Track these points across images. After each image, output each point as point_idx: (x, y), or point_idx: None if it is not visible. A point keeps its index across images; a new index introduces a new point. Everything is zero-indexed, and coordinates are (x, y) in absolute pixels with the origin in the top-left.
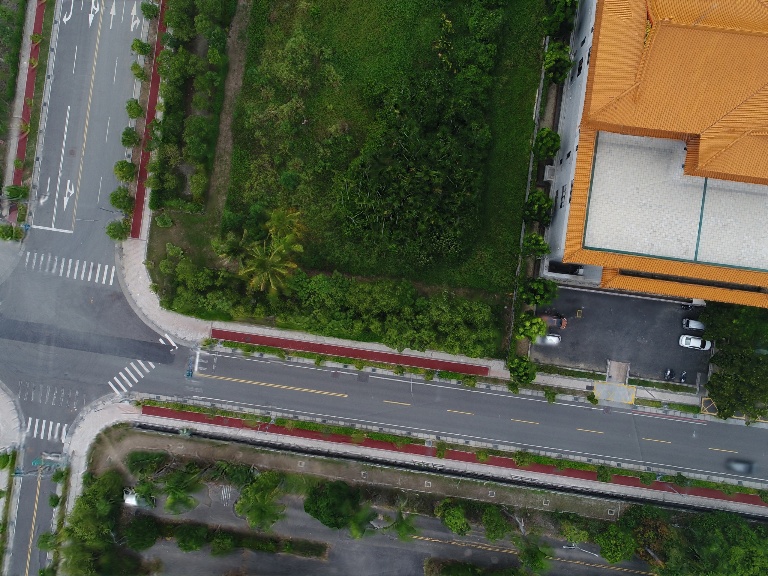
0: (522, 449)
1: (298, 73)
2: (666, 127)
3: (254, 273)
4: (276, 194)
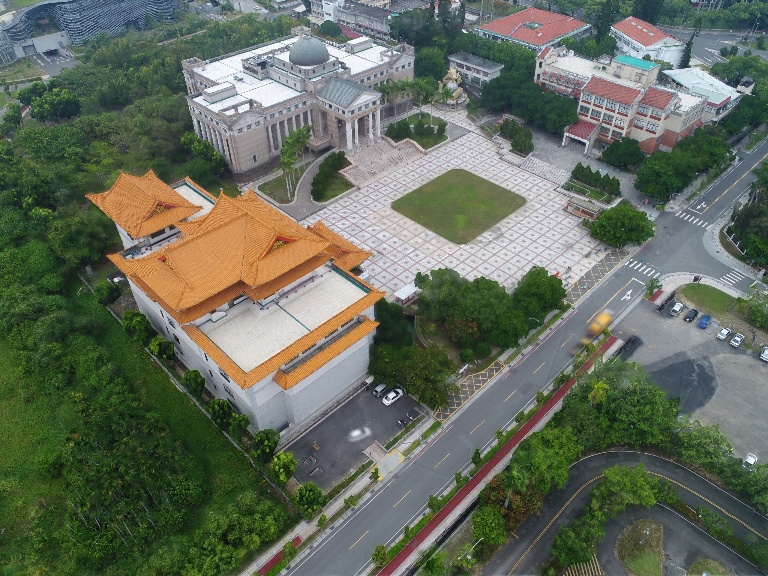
0: None
1: None
2: (221, 288)
3: None
4: None
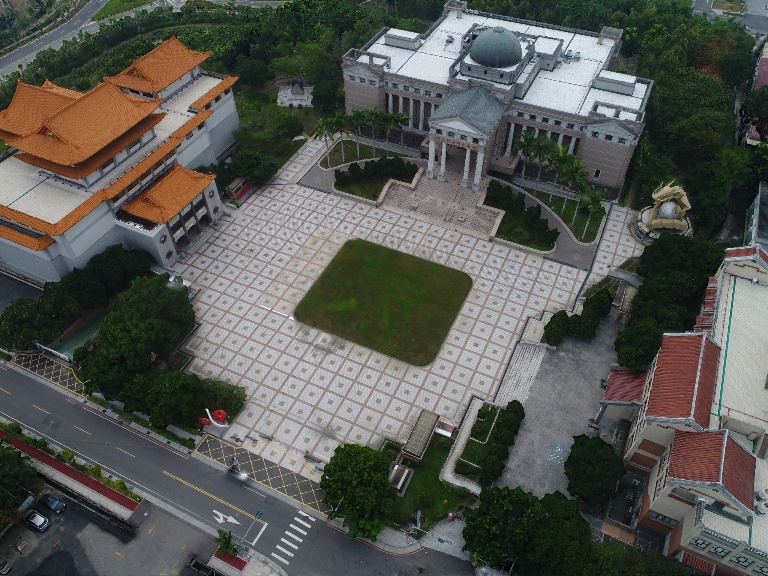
0: None
1: None
2: (12, 131)
3: None
4: None
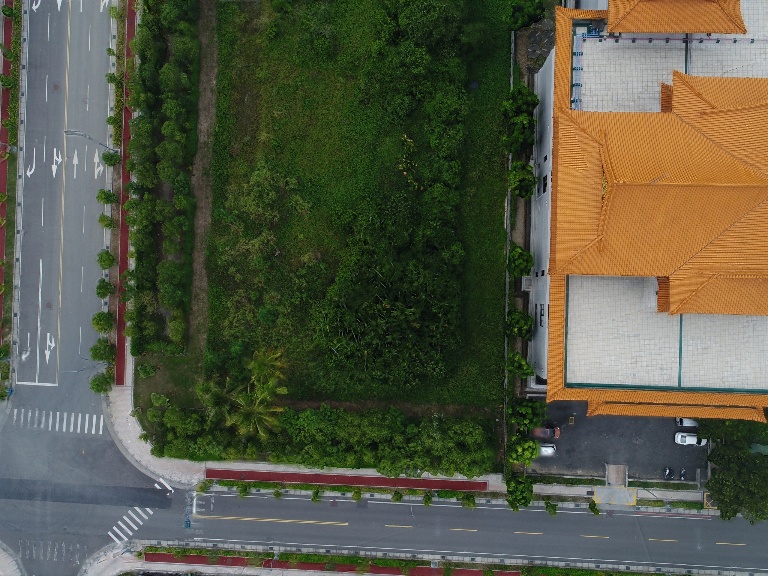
0: (529, 561)
1: (265, 206)
2: (634, 273)
3: (240, 427)
4: (256, 329)
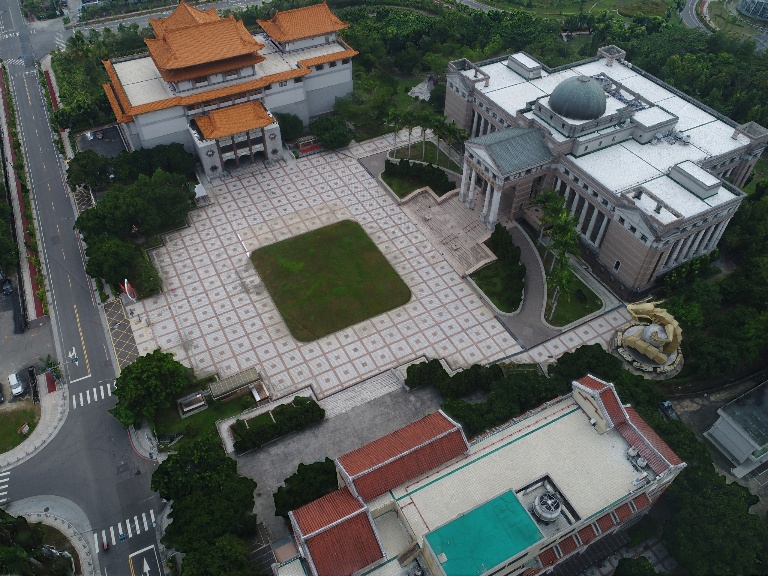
0: None
1: None
2: None
3: None
4: None
